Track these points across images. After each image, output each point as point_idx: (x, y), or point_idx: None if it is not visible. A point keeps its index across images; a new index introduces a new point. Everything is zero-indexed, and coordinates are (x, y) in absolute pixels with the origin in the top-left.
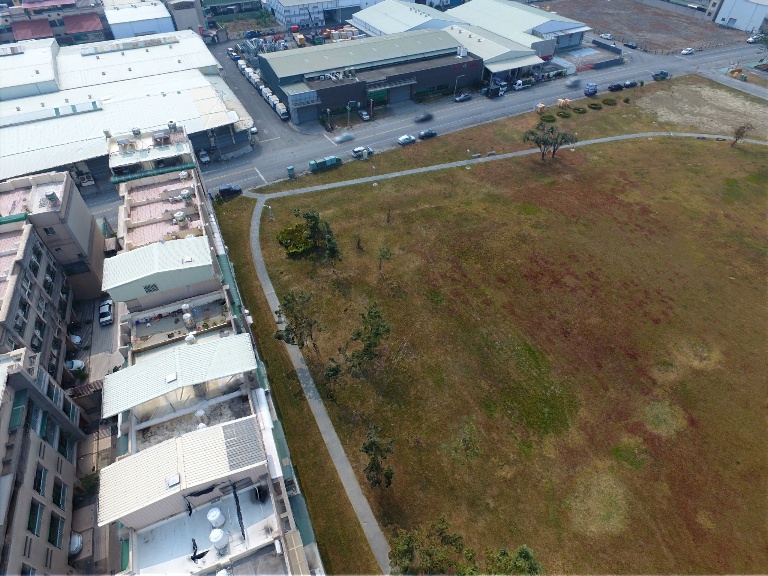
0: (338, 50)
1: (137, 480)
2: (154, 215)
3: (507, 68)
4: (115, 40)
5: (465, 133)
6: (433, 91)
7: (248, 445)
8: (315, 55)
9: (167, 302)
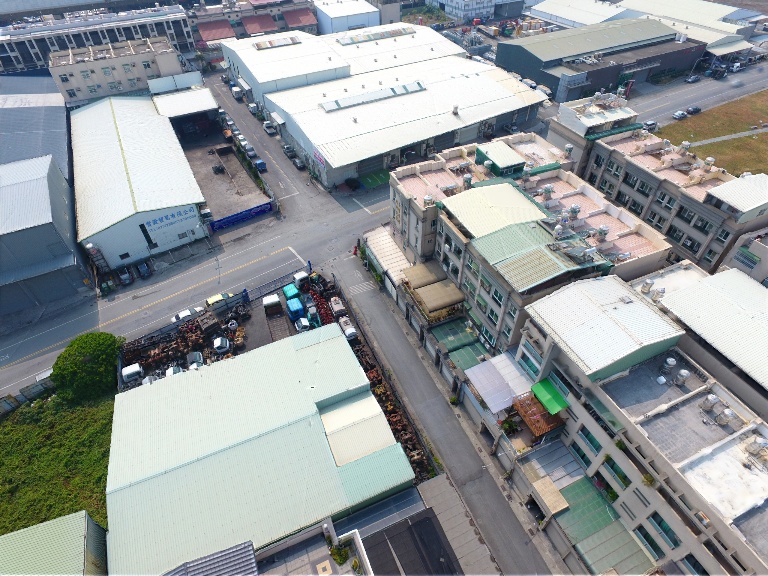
0: (576, 37)
1: None
2: (650, 165)
3: (728, 52)
4: (342, 32)
5: (725, 109)
6: (664, 73)
7: None
8: (559, 42)
9: (766, 225)
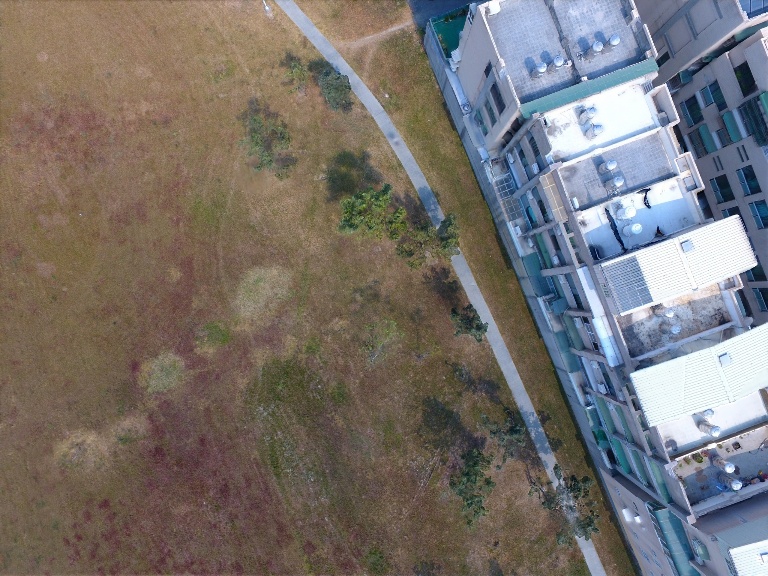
0: None
1: (720, 250)
2: None
3: None
4: None
5: None
6: None
7: (623, 282)
8: None
9: (763, 497)
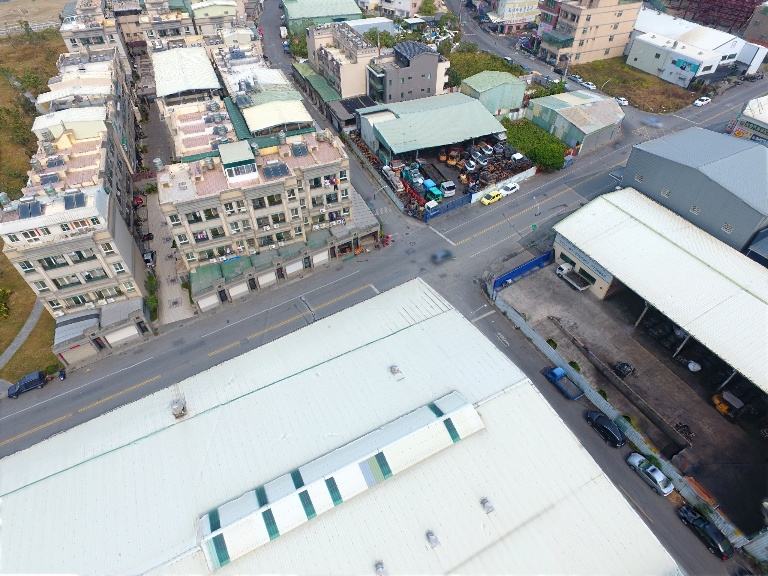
0: None
1: None
2: (80, 175)
3: None
4: None
5: None
6: None
7: None
8: None
9: None
